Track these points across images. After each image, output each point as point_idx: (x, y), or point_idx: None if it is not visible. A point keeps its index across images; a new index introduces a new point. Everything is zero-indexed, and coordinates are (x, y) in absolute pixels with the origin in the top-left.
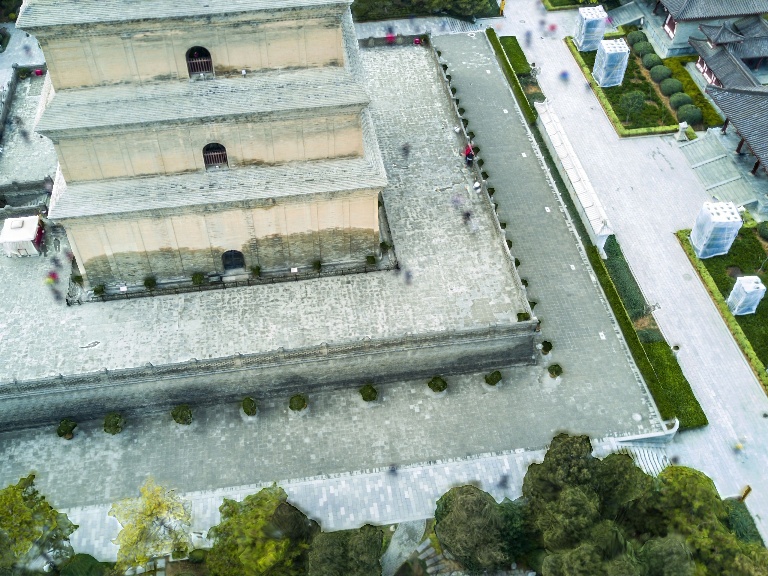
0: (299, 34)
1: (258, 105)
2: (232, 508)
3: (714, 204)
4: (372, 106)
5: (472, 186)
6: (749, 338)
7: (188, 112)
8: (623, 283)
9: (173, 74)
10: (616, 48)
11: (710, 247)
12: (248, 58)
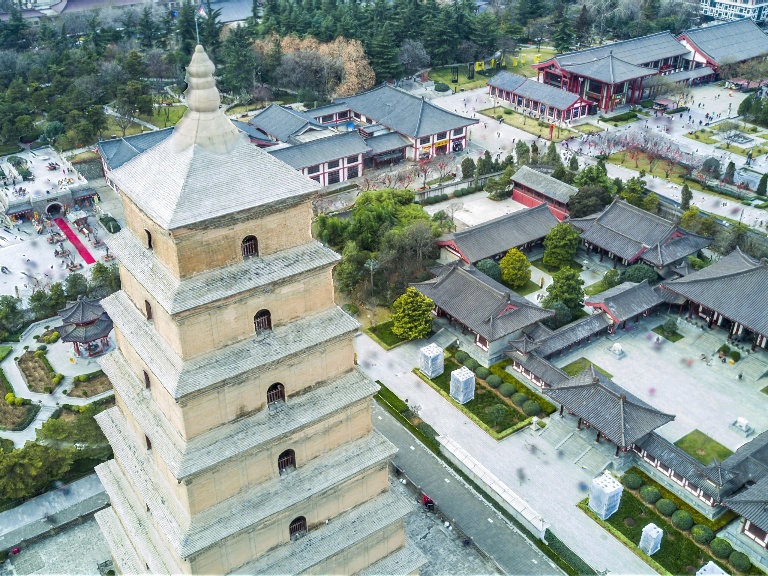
0: (363, 482)
1: (343, 542)
2: None
3: (599, 479)
4: None
5: (443, 526)
6: (668, 570)
7: (297, 568)
8: (571, 560)
9: (280, 543)
10: (465, 375)
11: (608, 510)
12: (330, 511)
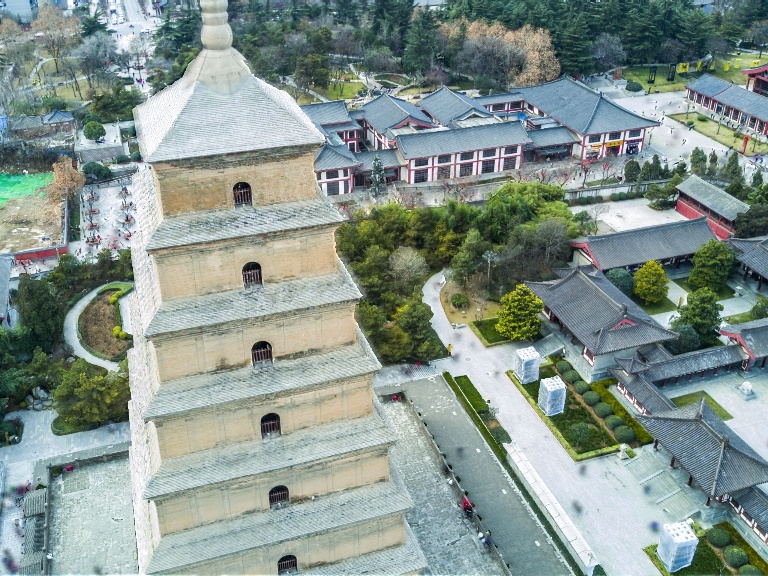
0: (357, 465)
1: (327, 523)
2: None
3: (672, 526)
4: None
5: (477, 536)
6: None
7: (271, 538)
8: None
9: (258, 508)
10: (555, 385)
11: (677, 562)
12: (317, 487)
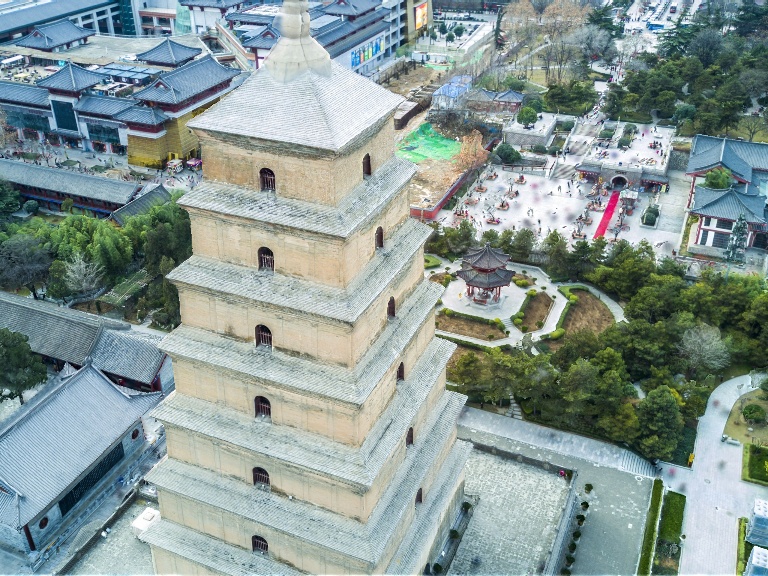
0: (333, 489)
1: (291, 527)
2: None
3: None
4: (480, 523)
5: None
6: None
7: (242, 510)
8: None
9: (243, 478)
10: (767, 562)
11: None
12: (295, 489)
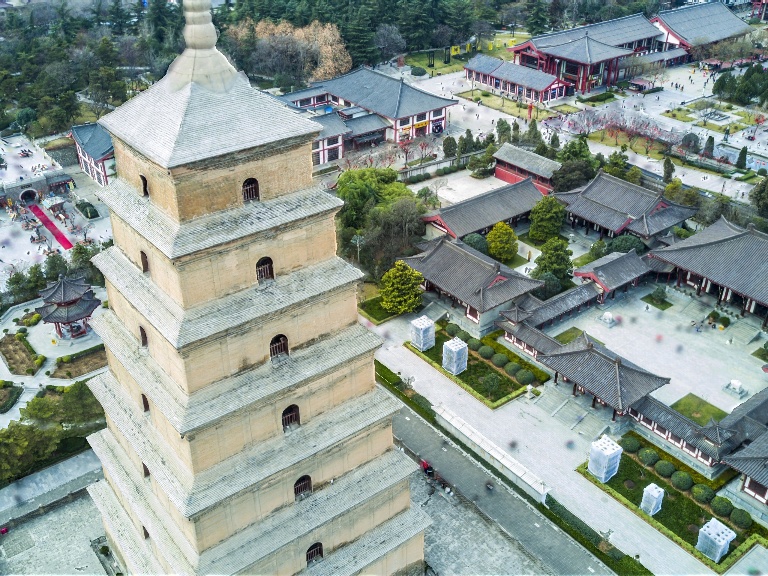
0: (368, 440)
1: (349, 502)
2: None
3: (598, 442)
4: None
5: (444, 492)
6: (670, 529)
7: (303, 529)
8: (573, 523)
9: (285, 503)
10: (458, 346)
11: (608, 473)
12: (335, 470)
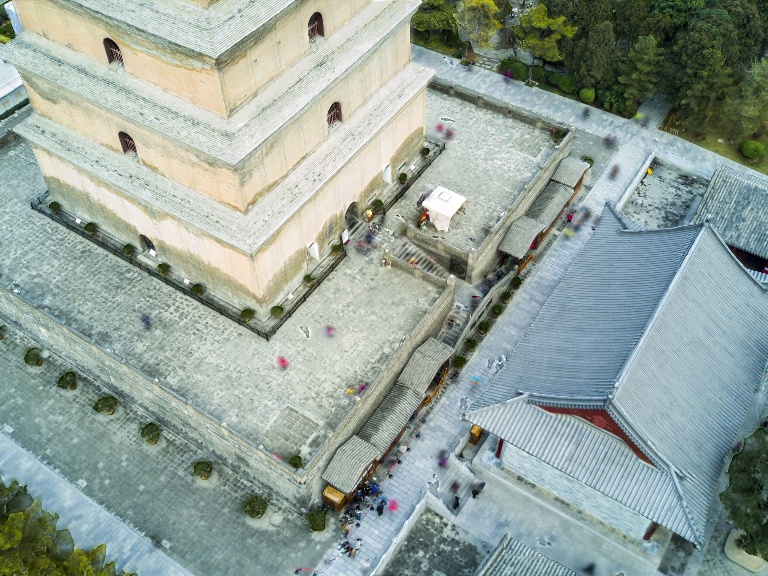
0: None
1: None
2: (435, 22)
3: None
4: None
5: None
6: None
7: None
8: None
9: None
10: None
11: None
12: None
